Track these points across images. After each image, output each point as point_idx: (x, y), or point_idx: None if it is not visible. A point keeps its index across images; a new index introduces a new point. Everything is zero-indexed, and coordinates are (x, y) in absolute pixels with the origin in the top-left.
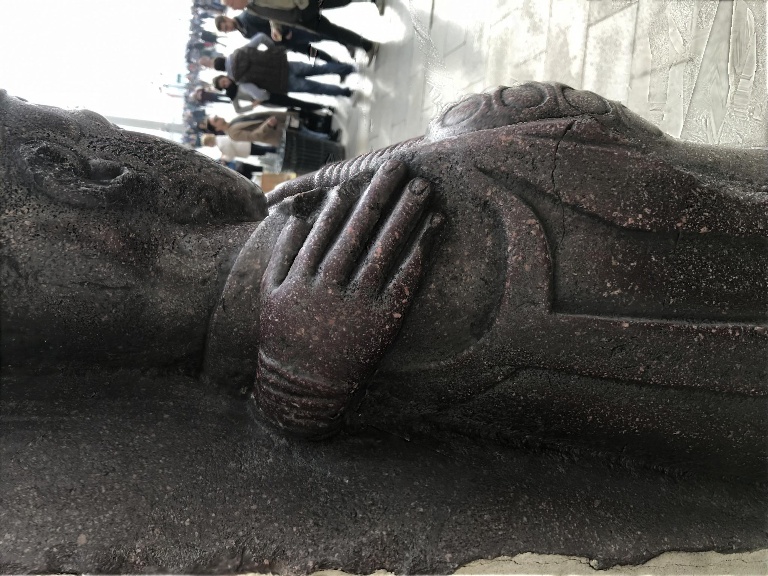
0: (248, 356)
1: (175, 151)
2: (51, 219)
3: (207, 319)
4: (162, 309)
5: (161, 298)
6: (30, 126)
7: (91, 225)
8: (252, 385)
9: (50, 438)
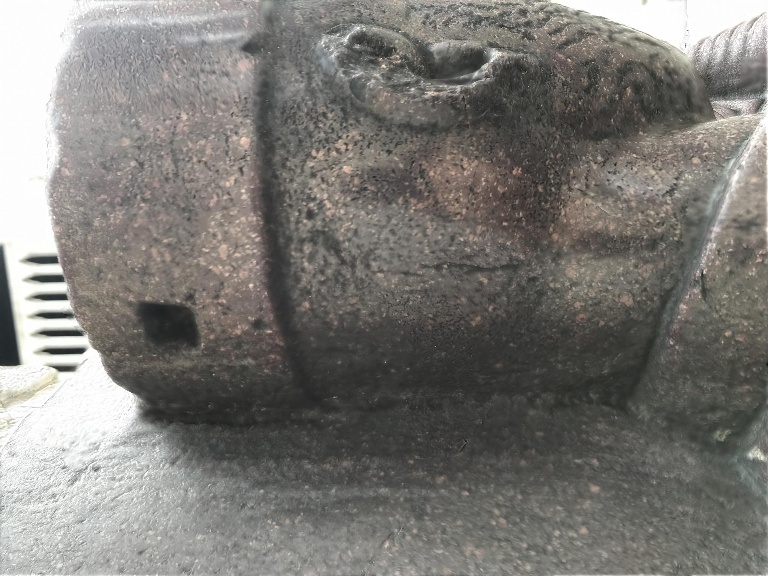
0: (747, 381)
1: (559, 11)
2: (383, 158)
3: (657, 313)
4: (571, 299)
5: (570, 280)
6: (330, 3)
7: (448, 160)
8: (742, 429)
9: (415, 532)
